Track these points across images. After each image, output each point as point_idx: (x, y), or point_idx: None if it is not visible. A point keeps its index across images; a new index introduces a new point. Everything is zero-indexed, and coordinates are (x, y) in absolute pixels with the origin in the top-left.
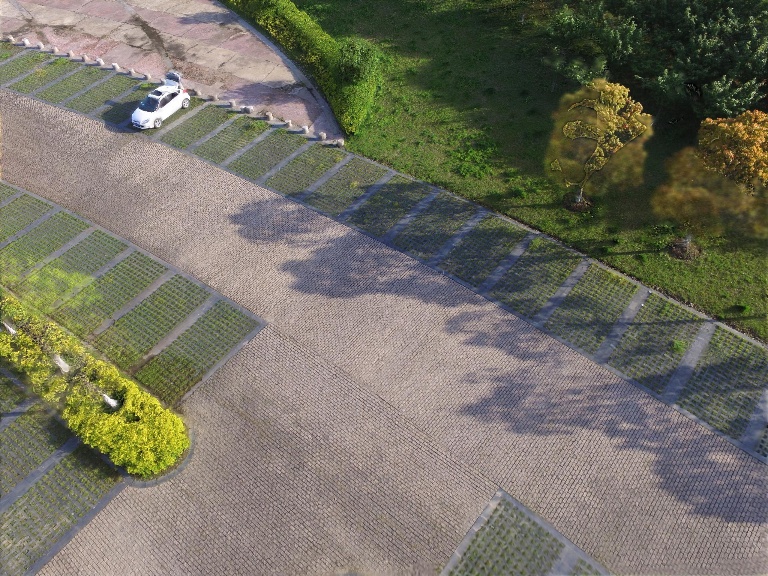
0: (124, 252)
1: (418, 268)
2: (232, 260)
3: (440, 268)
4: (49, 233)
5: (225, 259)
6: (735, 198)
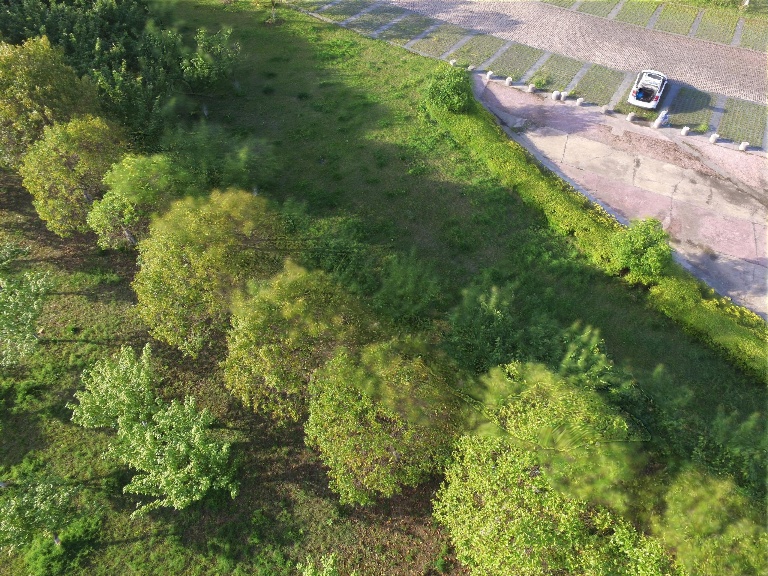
0: (576, 8)
1: (390, 1)
2: (504, 5)
3: (377, 0)
4: (637, 16)
5: (509, 5)
6: (167, 17)
